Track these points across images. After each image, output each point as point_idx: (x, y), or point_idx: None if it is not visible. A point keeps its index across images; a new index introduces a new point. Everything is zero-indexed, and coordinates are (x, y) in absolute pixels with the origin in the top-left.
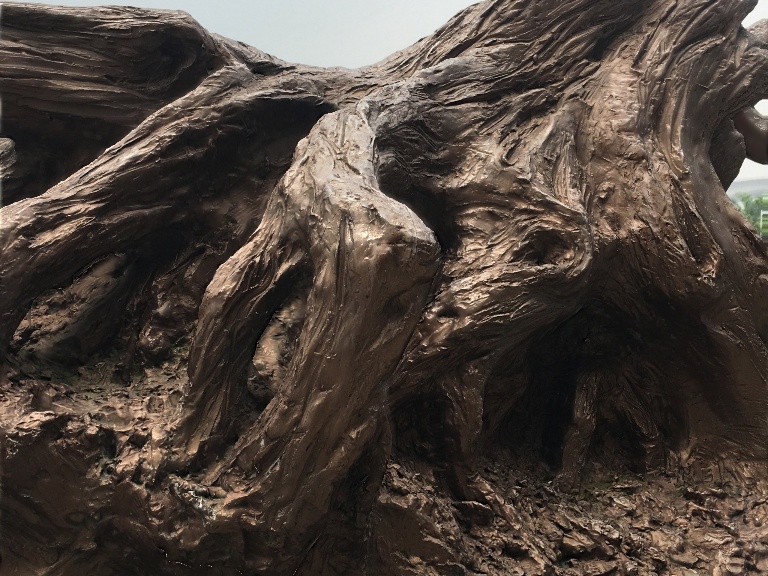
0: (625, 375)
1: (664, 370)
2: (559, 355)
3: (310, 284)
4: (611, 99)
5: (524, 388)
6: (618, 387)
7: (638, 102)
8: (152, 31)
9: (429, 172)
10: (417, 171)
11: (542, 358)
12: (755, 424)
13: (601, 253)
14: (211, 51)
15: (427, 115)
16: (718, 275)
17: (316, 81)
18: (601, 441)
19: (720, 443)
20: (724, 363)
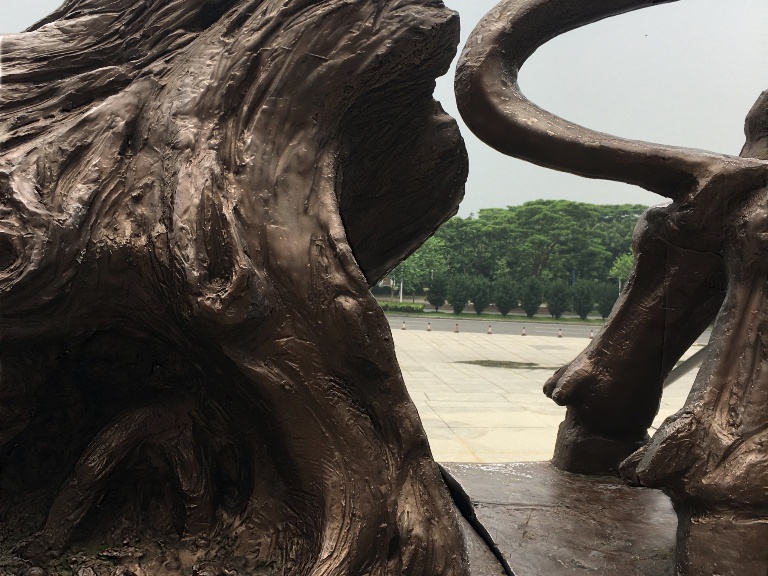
0: (192, 415)
1: (229, 412)
2: (132, 385)
3: None
4: (185, 76)
5: (25, 423)
6: (177, 429)
7: (211, 78)
8: None
9: None
10: None
11: (116, 387)
12: (310, 490)
13: (104, 263)
14: None
15: None
16: (235, 295)
17: None
18: (161, 493)
19: (280, 510)
20: (270, 408)
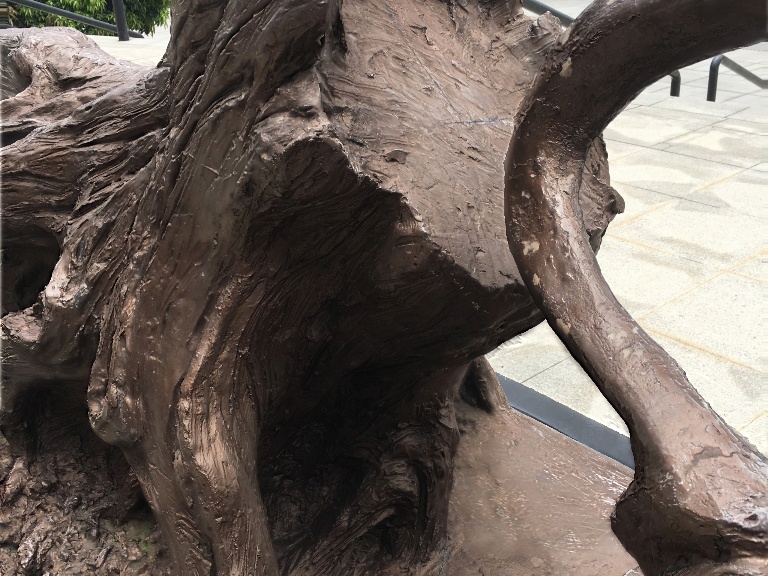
0: None
1: None
2: None
3: (4, 276)
4: None
5: None
6: None
7: (154, 179)
8: (8, 62)
9: (50, 211)
10: (24, 213)
11: None
12: None
13: None
14: (28, 77)
15: (39, 163)
16: (104, 420)
17: (83, 98)
18: None
19: None
20: None
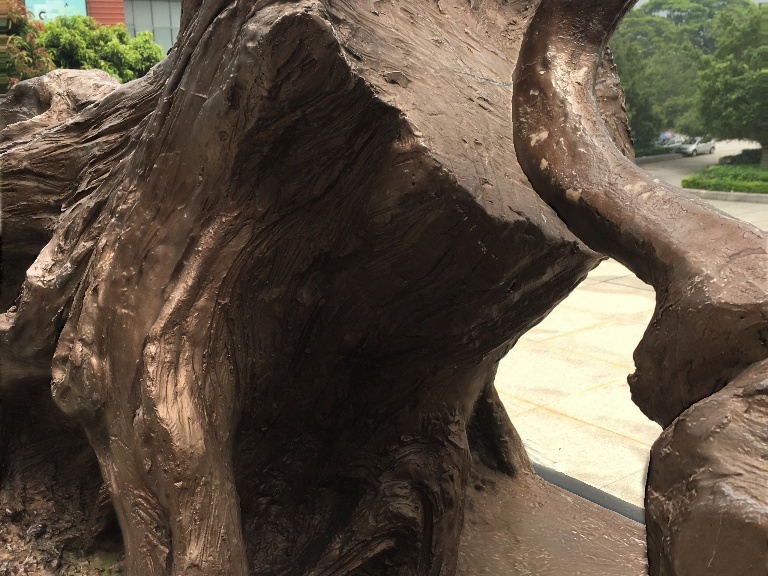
0: None
1: None
2: None
3: None
4: None
5: None
6: None
7: (146, 131)
8: (31, 95)
9: (48, 213)
10: (21, 215)
11: None
12: None
13: None
14: (48, 104)
15: (42, 160)
16: (66, 385)
17: None
18: None
19: None
20: None
